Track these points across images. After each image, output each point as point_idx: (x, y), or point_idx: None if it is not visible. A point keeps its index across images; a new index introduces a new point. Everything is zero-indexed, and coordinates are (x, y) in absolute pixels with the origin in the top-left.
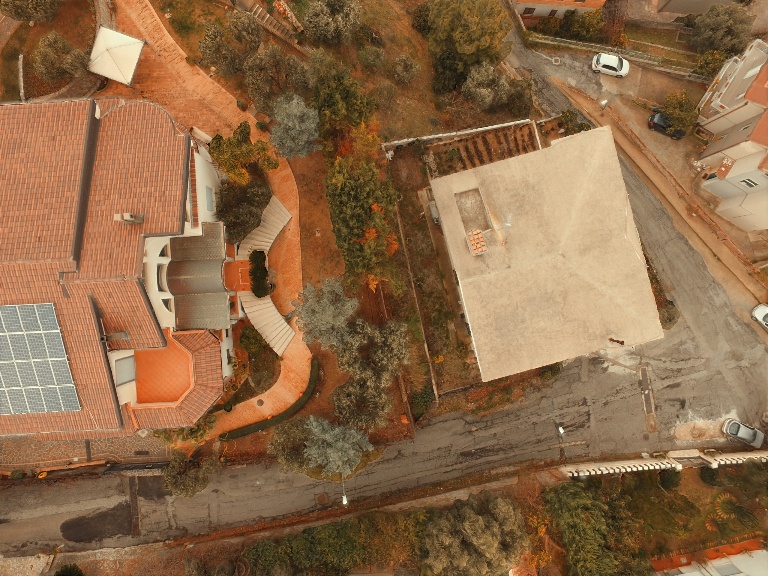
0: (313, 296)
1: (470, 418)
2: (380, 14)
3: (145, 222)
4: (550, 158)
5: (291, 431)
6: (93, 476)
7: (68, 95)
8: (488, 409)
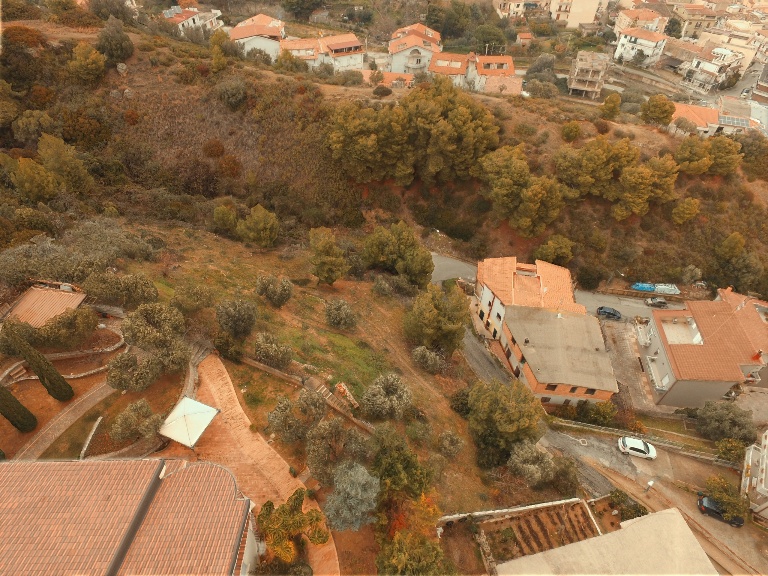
0: None
1: None
2: (422, 397)
3: None
4: (625, 543)
5: None
6: None
7: (127, 454)
8: None
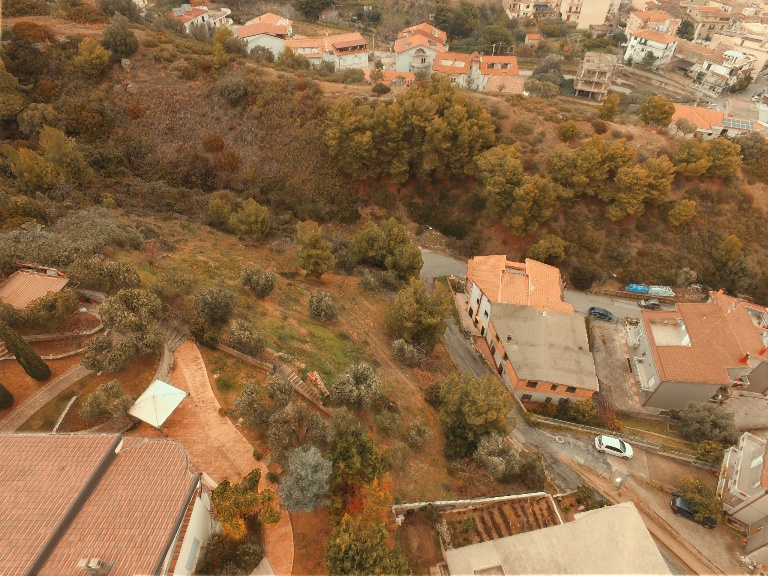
0: None
1: None
2: (397, 388)
3: (111, 573)
4: (577, 534)
5: None
6: None
7: (97, 433)
8: None
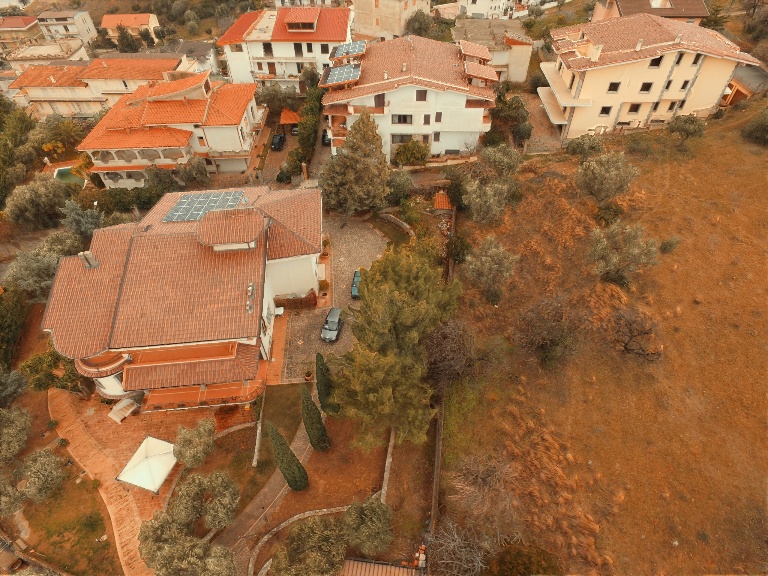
0: None
1: None
2: None
3: None
4: None
5: None
6: None
7: None
8: None
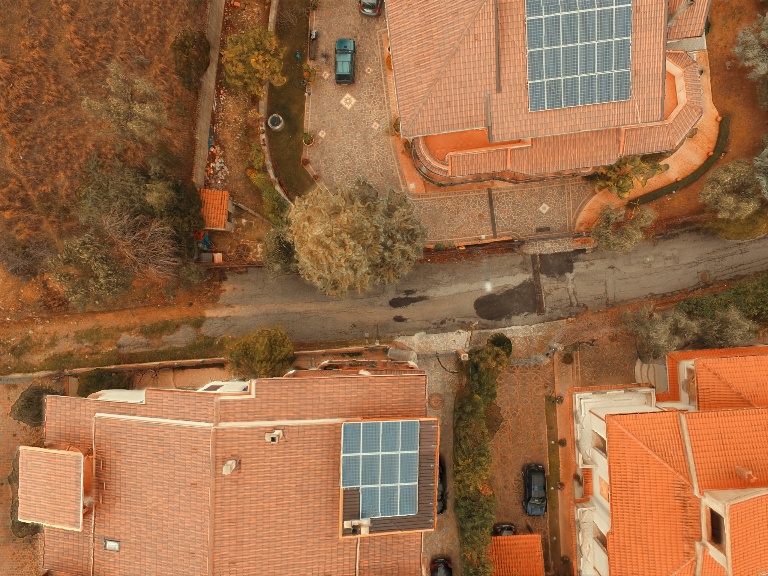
0: None
1: None
2: None
3: None
4: None
5: (737, 170)
6: (499, 254)
7: None
8: None
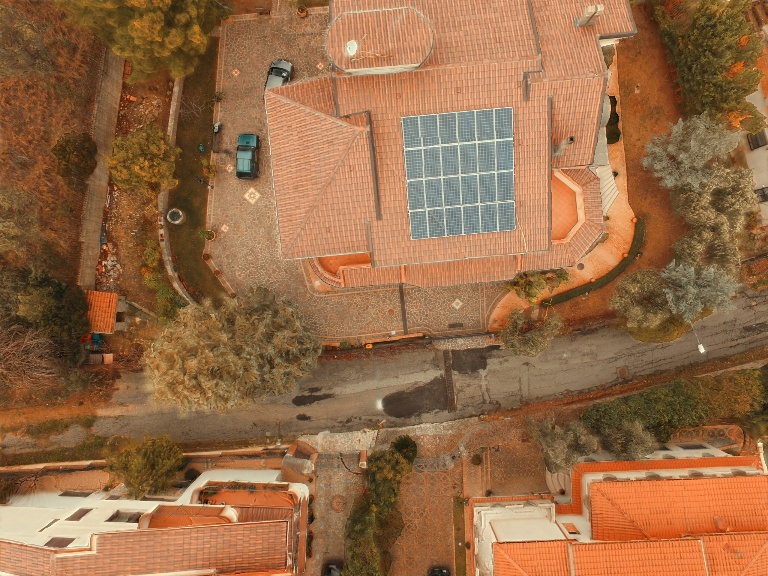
0: (679, 134)
1: (750, 292)
2: None
3: (596, 24)
4: None
5: (645, 280)
6: (409, 350)
7: None
8: (766, 283)
